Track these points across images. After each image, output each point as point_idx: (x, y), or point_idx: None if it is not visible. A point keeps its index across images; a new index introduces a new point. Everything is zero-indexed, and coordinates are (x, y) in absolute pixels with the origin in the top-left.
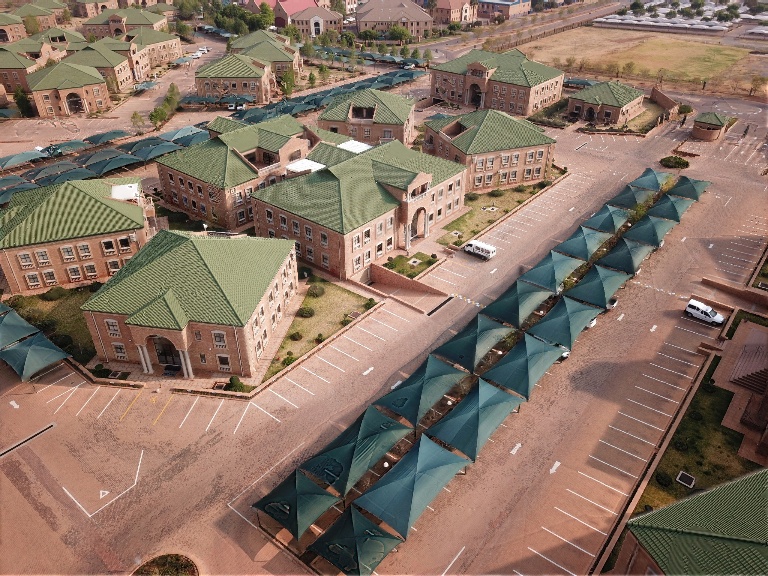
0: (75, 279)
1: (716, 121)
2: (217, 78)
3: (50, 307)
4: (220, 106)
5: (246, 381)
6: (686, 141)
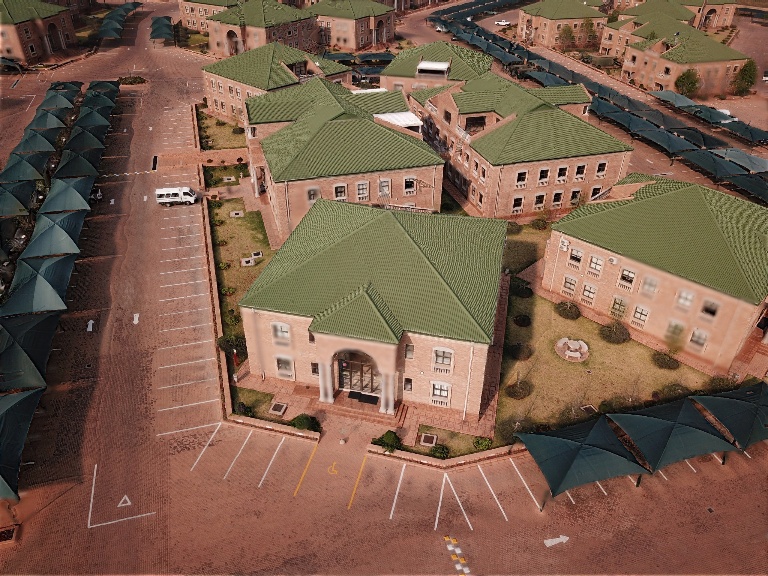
0: None
1: None
2: None
3: None
4: None
5: None
6: None
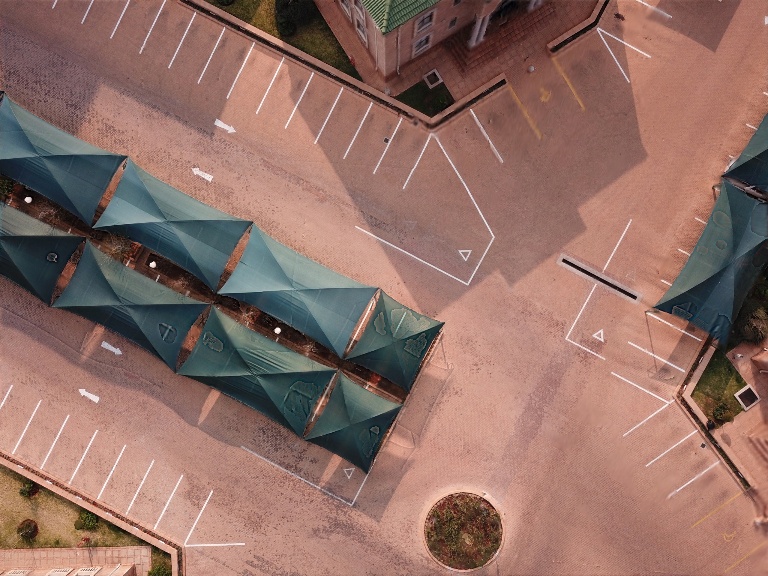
0: None
1: None
2: None
3: None
4: None
5: (144, 569)
6: None
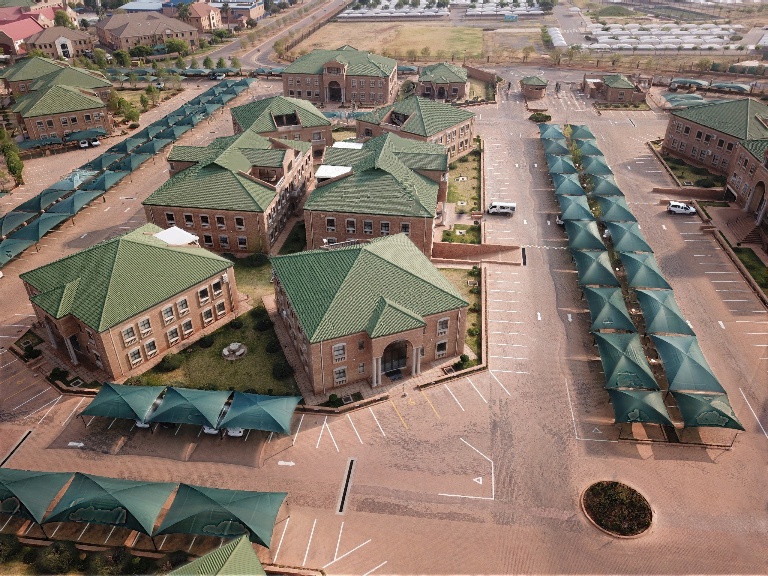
0: (173, 342)
1: (540, 82)
2: (51, 115)
3: (182, 376)
4: (64, 146)
5: None
6: (527, 101)
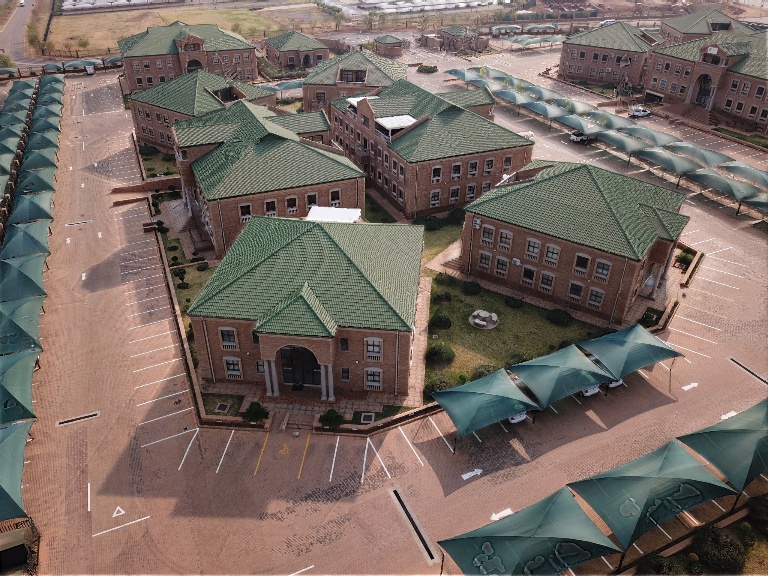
0: None
1: (396, 40)
2: None
3: (471, 361)
4: None
5: (674, 254)
6: None
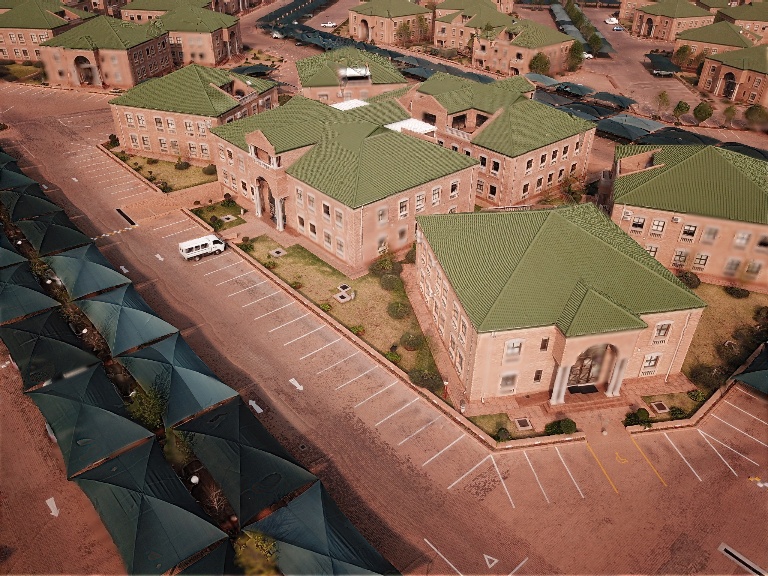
0: None
1: None
2: None
3: None
4: None
5: (119, 147)
6: None
